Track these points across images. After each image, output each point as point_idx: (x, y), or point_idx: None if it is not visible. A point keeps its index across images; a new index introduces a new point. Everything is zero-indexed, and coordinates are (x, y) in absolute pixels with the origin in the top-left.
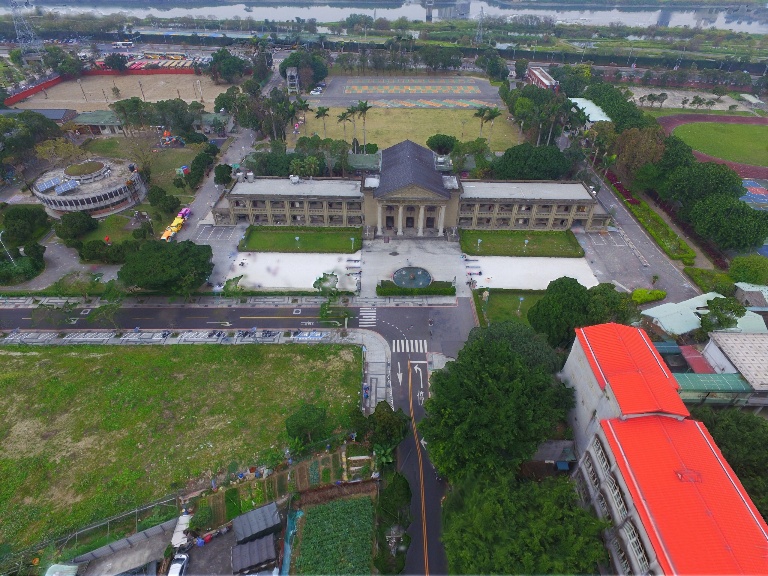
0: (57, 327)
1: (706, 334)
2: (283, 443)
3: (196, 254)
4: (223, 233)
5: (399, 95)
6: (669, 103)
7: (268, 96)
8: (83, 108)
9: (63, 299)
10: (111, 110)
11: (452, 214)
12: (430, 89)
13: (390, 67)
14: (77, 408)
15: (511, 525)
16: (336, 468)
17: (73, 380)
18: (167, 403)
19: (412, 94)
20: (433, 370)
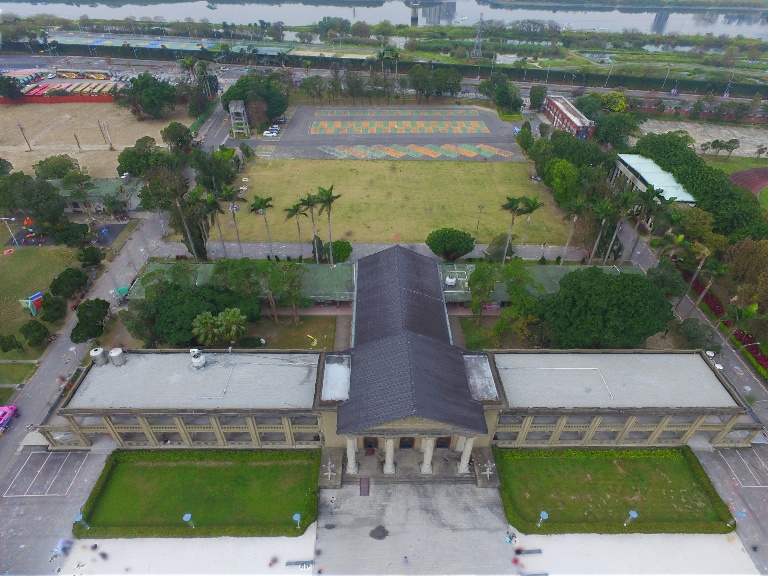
0: None
1: None
2: None
3: None
4: (60, 473)
5: (382, 137)
6: None
7: (206, 139)
8: None
9: None
10: None
11: None
12: (423, 126)
13: (370, 94)
14: None
15: None
16: None
17: None
18: None
19: (399, 135)
20: None
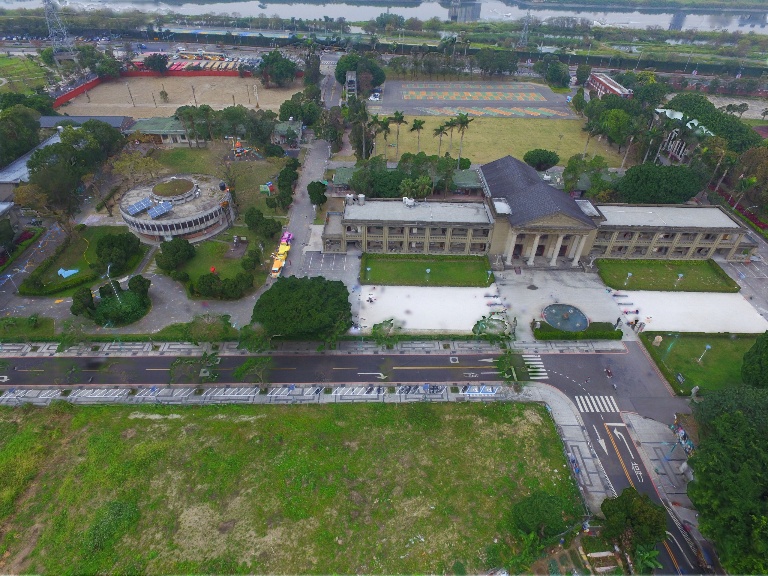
0: (189, 381)
1: None
2: (506, 536)
3: (335, 293)
4: (335, 262)
5: (462, 102)
6: (744, 113)
7: (325, 102)
8: (133, 113)
9: (185, 345)
10: (169, 117)
11: (587, 242)
12: (492, 96)
13: (445, 71)
14: (248, 489)
15: None
16: (580, 569)
17: (231, 451)
18: (351, 482)
19: (475, 101)
20: (668, 445)
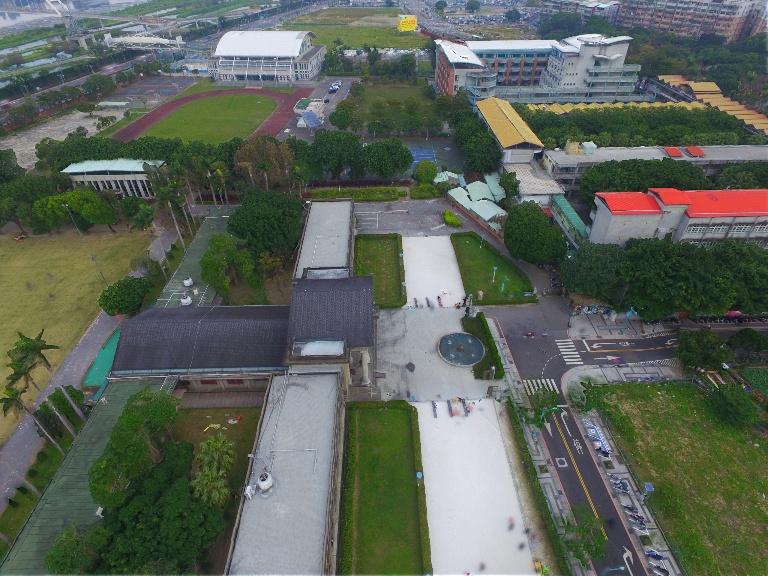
0: None
1: (508, 200)
2: (746, 437)
3: None
4: None
5: None
6: None
7: None
8: None
9: None
10: None
11: None
12: None
13: None
14: None
15: (764, 266)
16: None
17: None
18: None
19: None
20: None
